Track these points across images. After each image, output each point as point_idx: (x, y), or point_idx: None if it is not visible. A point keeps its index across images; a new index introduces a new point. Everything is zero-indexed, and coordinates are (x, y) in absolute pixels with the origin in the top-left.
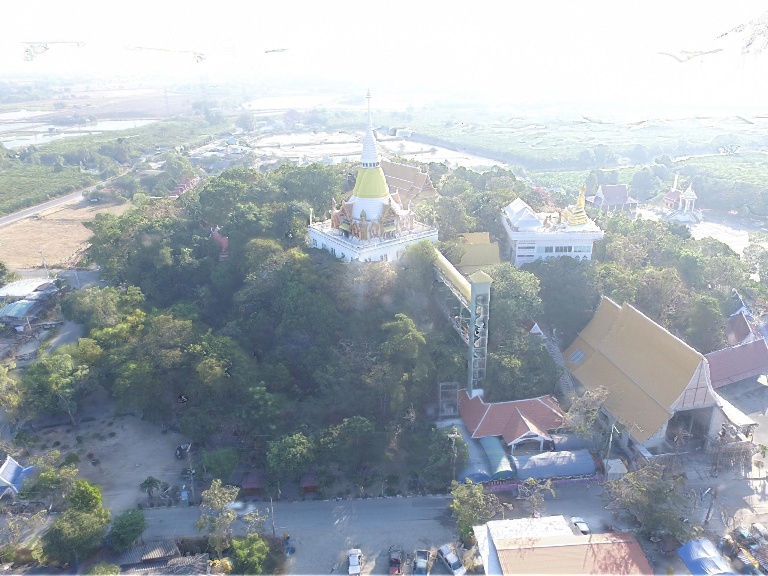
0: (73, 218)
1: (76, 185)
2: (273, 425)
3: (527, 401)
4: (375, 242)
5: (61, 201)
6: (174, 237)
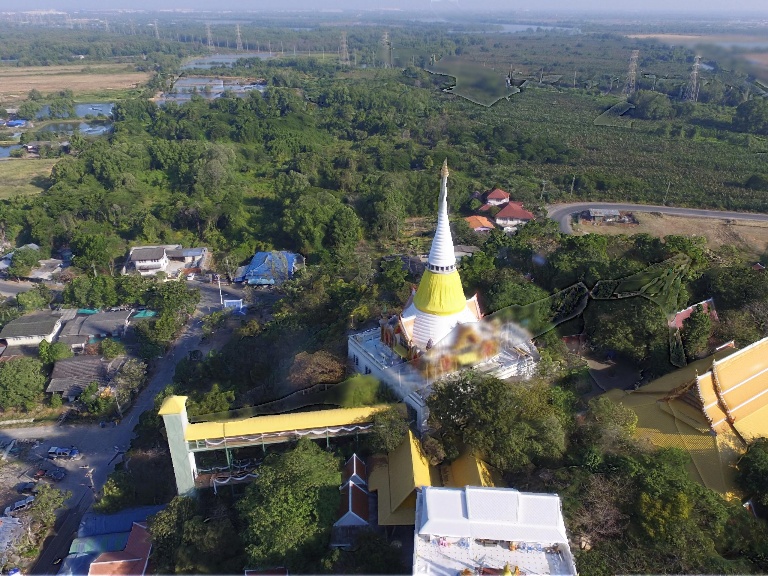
0: (743, 237)
1: None
2: (192, 378)
3: (143, 570)
4: (387, 351)
5: None
6: (497, 261)
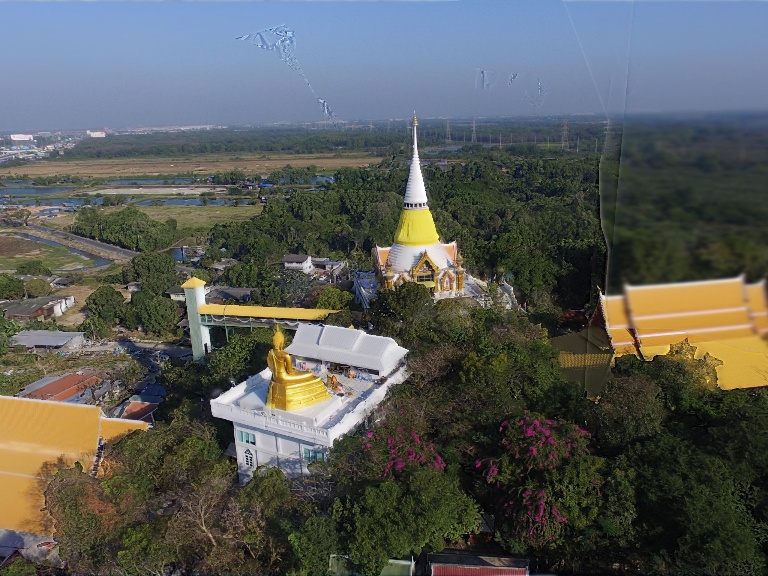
0: None
1: None
2: None
3: None
4: None
5: None
6: None
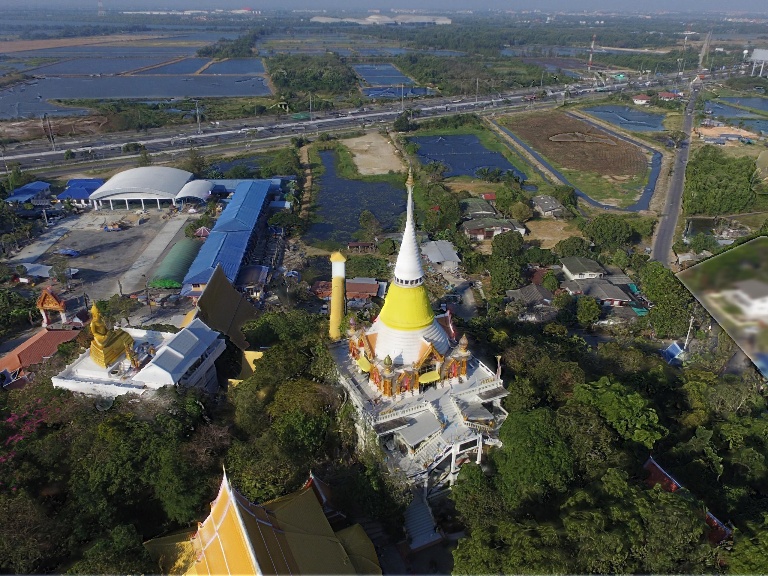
0: None
1: None
2: None
3: None
4: None
5: None
6: None
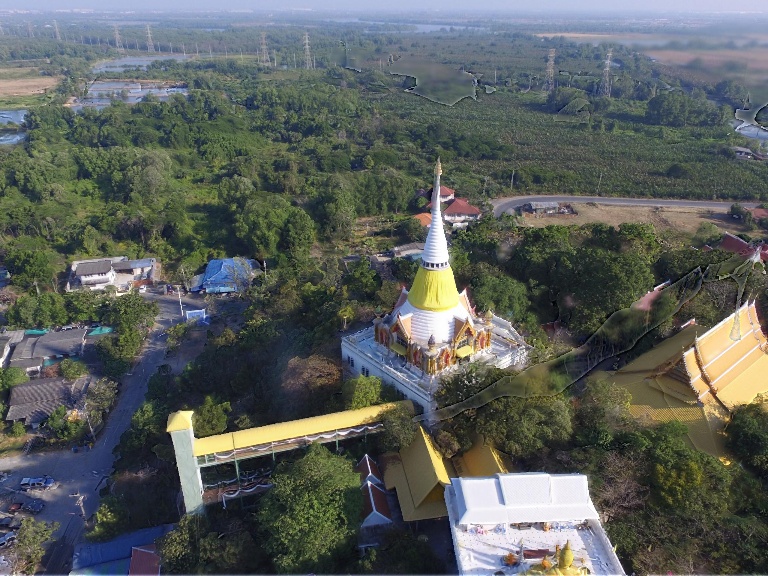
0: (672, 223)
1: (764, 196)
2: (170, 393)
3: None
4: (382, 350)
5: (718, 205)
6: None
